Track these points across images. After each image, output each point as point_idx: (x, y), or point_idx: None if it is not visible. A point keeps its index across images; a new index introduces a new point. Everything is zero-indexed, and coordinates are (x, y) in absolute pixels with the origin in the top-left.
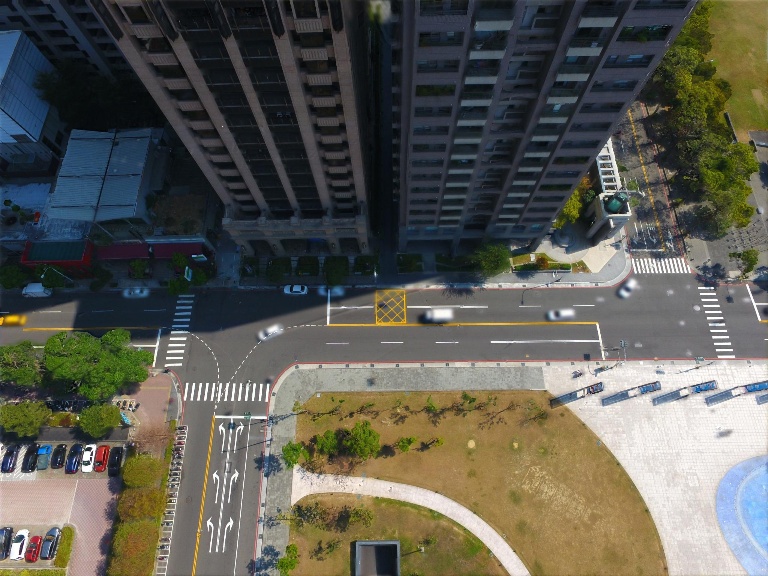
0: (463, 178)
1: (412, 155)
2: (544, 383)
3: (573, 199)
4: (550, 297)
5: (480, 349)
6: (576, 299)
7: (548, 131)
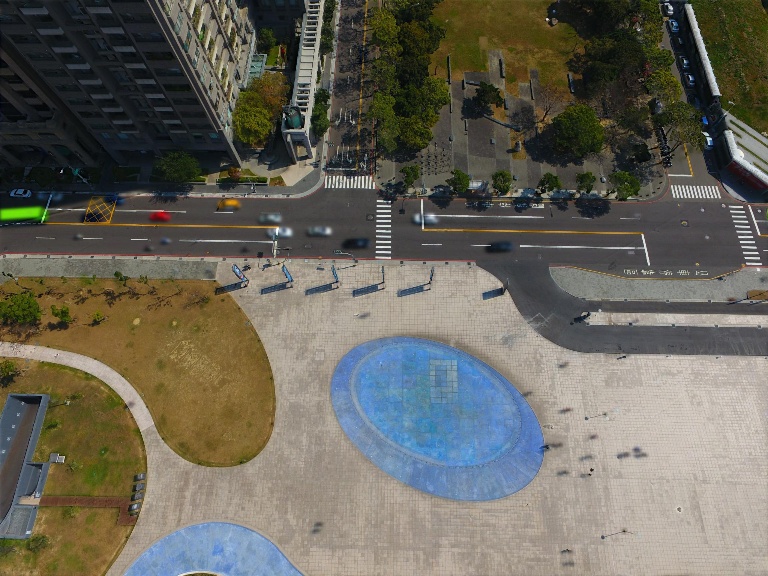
0: (87, 75)
1: (18, 47)
2: (215, 275)
3: (258, 116)
4: (243, 205)
5: (168, 246)
6: (266, 207)
7: (108, 22)
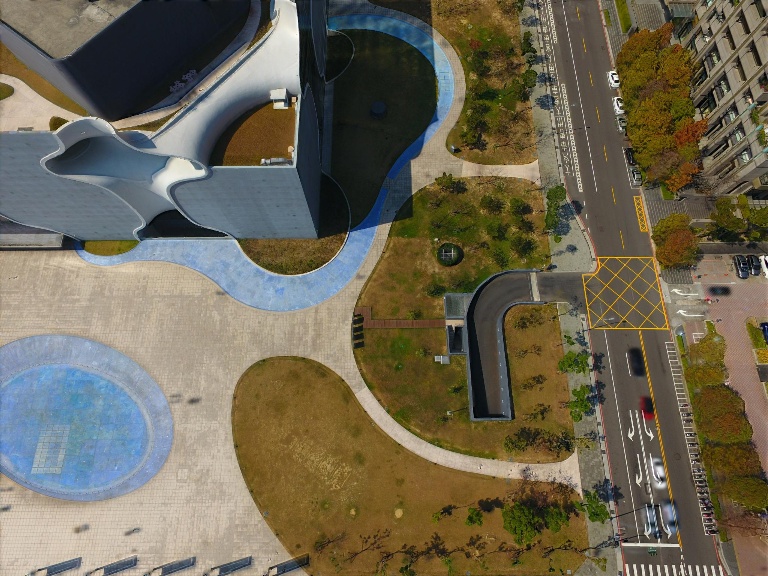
0: None
1: None
2: None
3: None
4: None
5: None
6: None
7: None
